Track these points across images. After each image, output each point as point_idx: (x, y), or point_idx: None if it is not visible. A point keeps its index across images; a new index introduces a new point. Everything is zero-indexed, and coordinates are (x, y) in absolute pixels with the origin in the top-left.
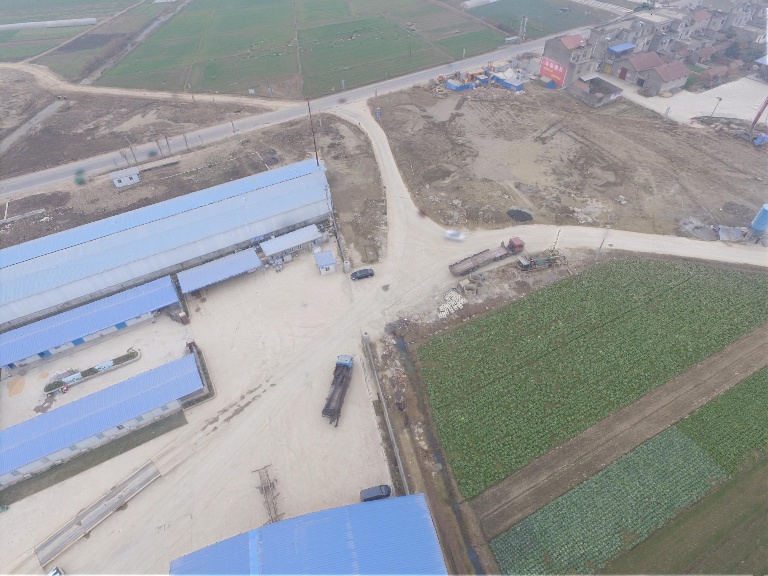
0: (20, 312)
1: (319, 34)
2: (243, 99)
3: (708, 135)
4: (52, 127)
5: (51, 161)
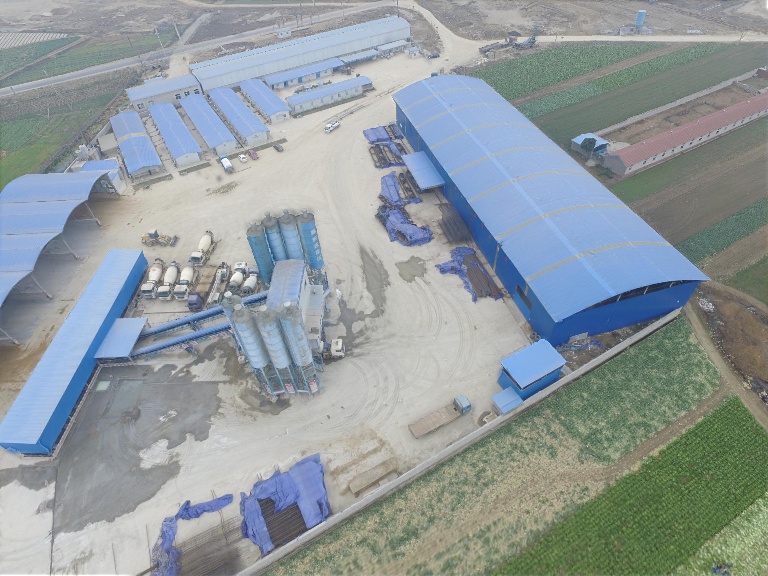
0: (267, 71)
1: None
2: (332, 3)
3: (624, 1)
4: (217, 20)
5: (228, 34)
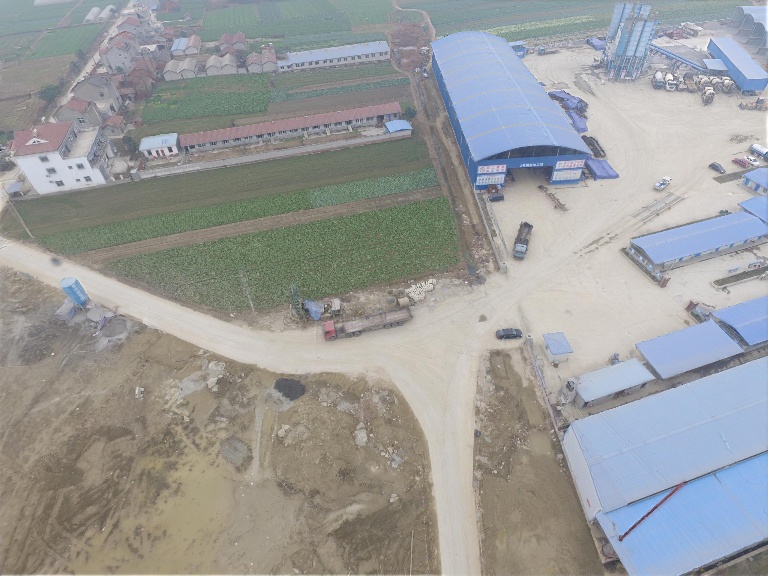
0: None
1: None
2: None
3: None
4: None
5: None
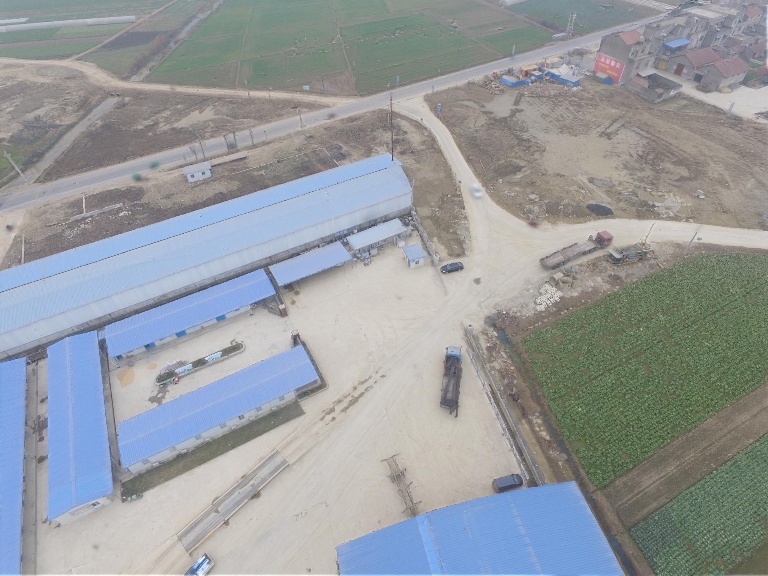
0: (121, 304)
1: (362, 31)
2: (298, 95)
3: None
4: (112, 123)
5: (117, 157)
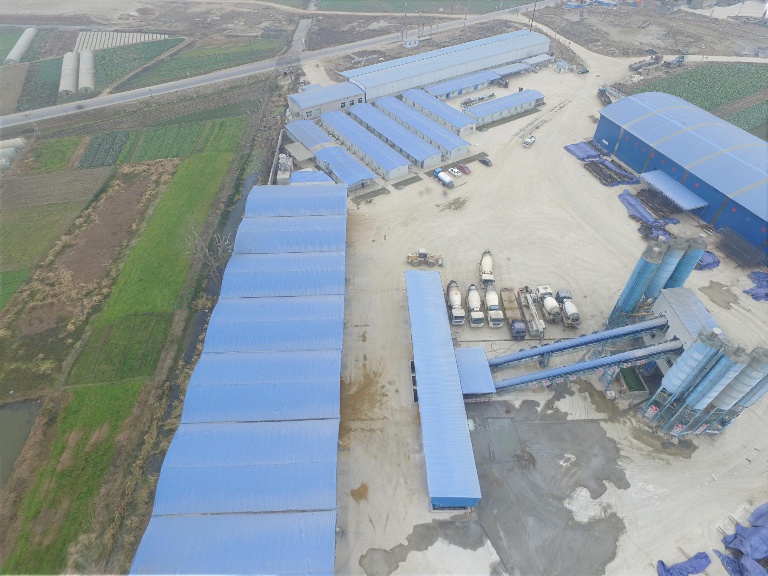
0: (424, 81)
1: None
2: (437, 14)
3: (738, 23)
4: (326, 27)
5: (345, 41)
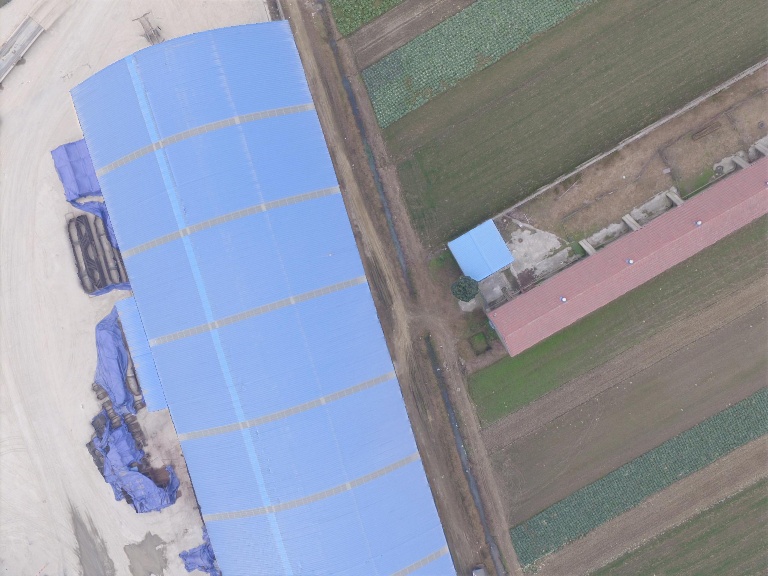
0: None
1: None
2: None
3: None
4: None
5: None
